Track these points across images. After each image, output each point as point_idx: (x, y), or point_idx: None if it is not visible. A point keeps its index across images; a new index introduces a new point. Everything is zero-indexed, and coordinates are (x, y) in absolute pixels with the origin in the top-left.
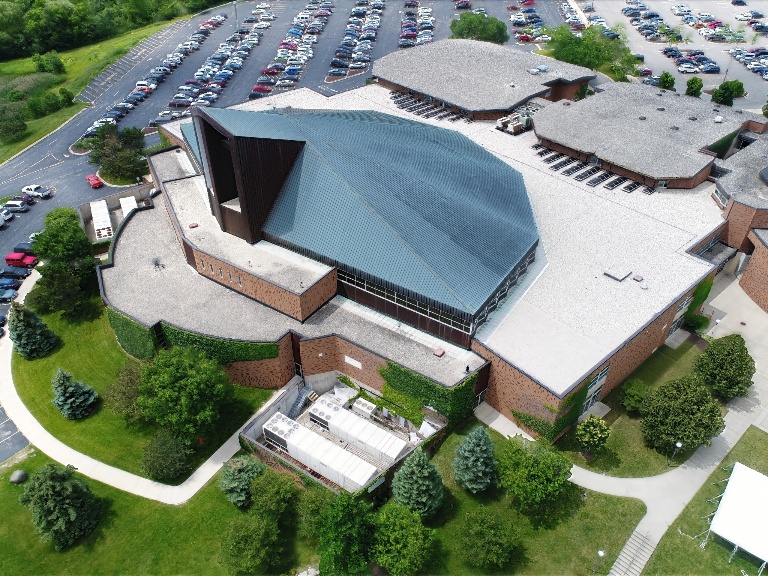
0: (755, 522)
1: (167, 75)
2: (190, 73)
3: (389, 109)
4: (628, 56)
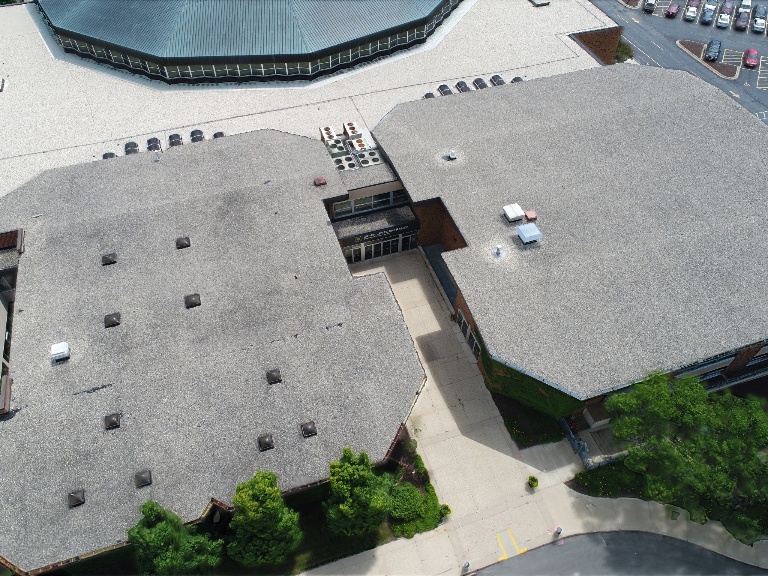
0: None
1: None
2: None
3: (496, 71)
4: None
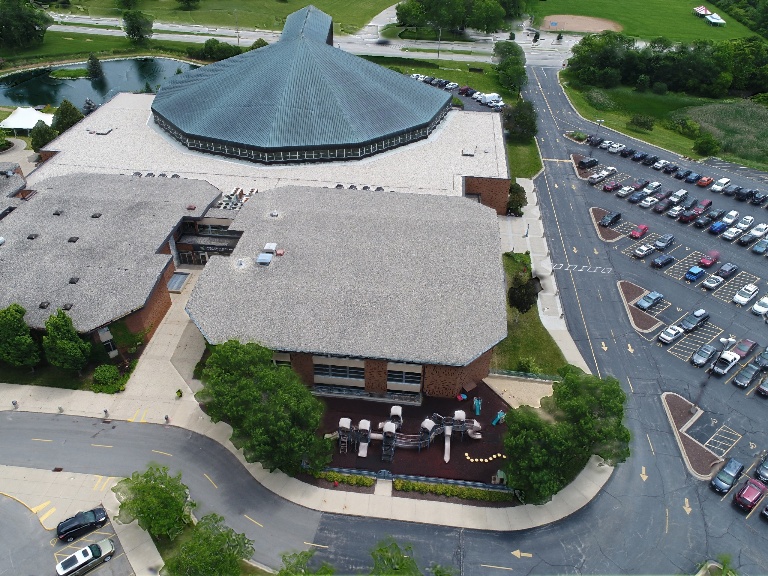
0: (45, 114)
1: (766, 208)
2: (764, 221)
3: (387, 186)
4: (154, 488)
